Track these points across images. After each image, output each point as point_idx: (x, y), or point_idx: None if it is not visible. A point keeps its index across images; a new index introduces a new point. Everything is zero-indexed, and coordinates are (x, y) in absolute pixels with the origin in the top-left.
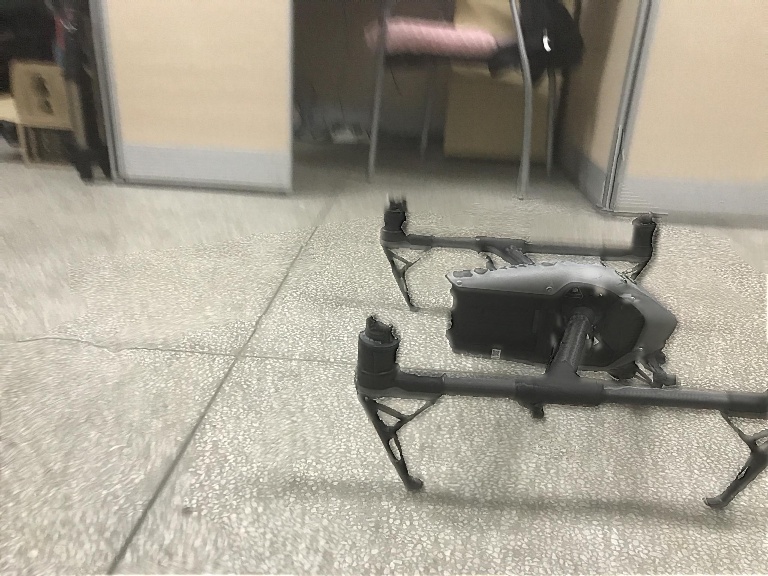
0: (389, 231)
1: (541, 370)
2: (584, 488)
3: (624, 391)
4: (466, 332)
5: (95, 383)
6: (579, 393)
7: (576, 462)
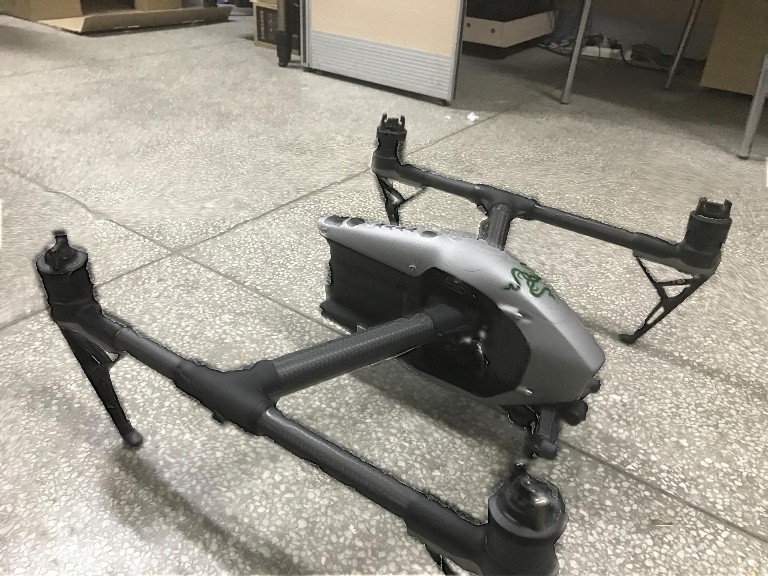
0: (378, 155)
1: None
2: (293, 533)
3: (283, 431)
4: (340, 294)
5: (41, 241)
6: (229, 409)
7: (330, 498)
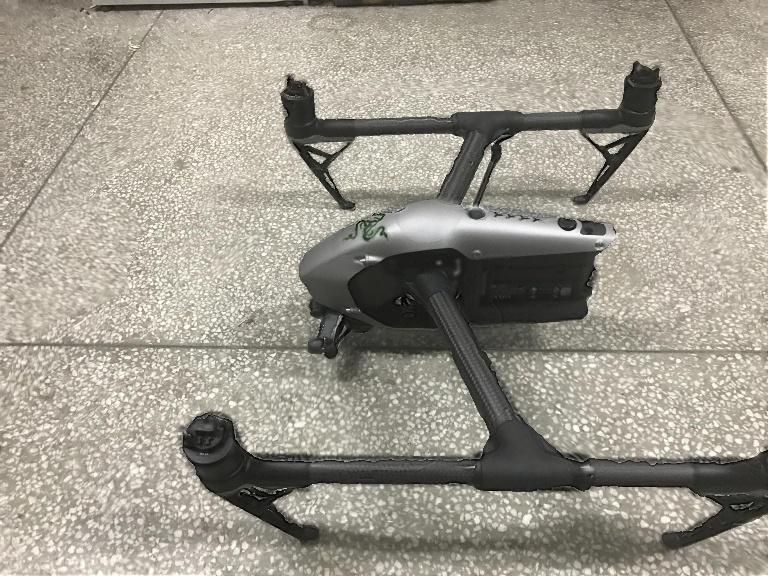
0: None
1: (450, 365)
2: None
3: None
4: None
5: None
6: None
7: None
